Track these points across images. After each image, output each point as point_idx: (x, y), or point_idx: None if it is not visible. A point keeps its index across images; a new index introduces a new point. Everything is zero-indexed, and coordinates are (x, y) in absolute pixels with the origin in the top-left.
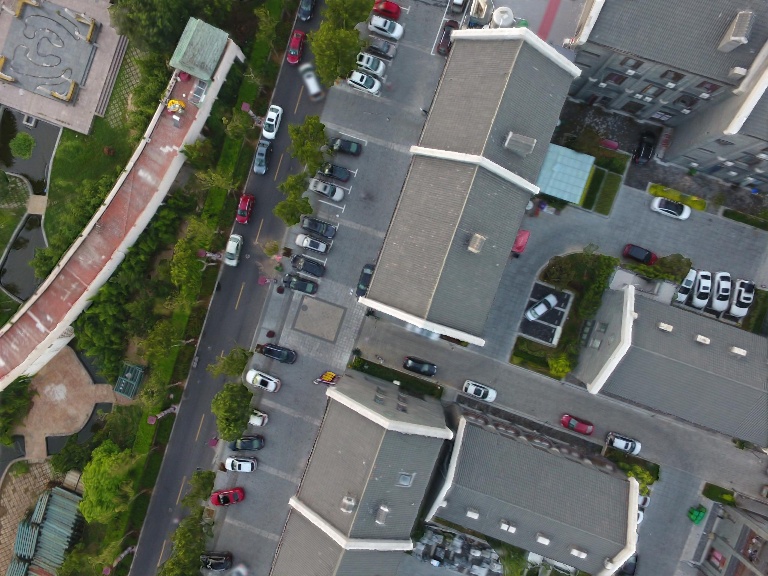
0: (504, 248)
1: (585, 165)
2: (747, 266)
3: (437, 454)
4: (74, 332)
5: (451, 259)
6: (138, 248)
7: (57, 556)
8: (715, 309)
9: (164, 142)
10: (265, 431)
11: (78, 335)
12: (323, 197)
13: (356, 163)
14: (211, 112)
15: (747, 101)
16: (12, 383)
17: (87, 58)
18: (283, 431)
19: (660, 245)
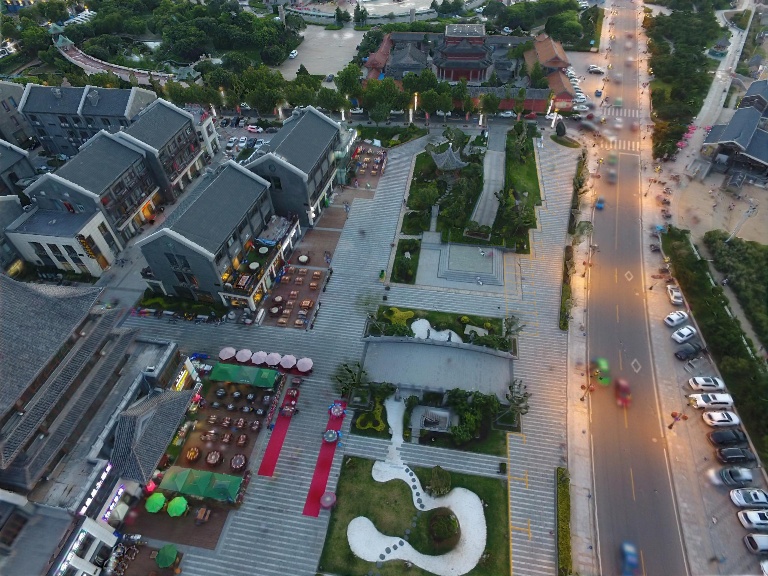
0: (58, 109)
1: None
2: None
3: None
4: None
5: None
6: None
7: None
8: None
9: None
10: None
11: None
12: None
13: None
14: None
15: None
16: None
17: None
18: None
19: None
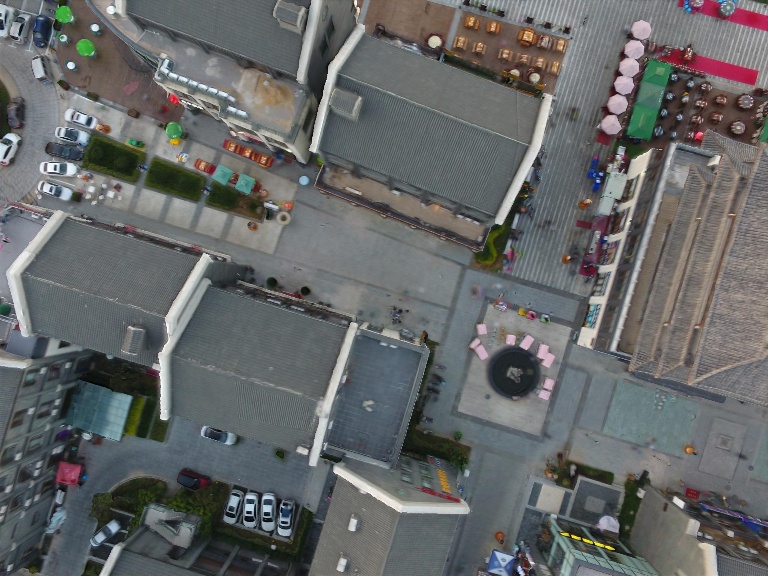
0: None
1: (124, 404)
2: (295, 485)
3: None
4: None
5: None
6: None
7: None
8: (264, 529)
9: None
10: None
11: None
12: None
13: None
14: None
15: None
16: None
17: None
18: None
19: (215, 467)
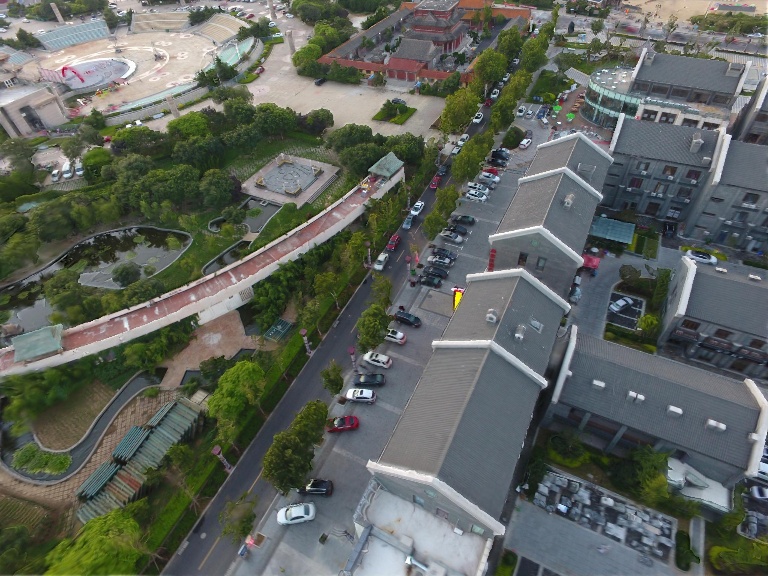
0: (587, 218)
1: (630, 227)
2: None
3: (559, 321)
4: (254, 289)
5: (554, 207)
6: (319, 247)
7: (153, 462)
8: None
9: (353, 203)
10: (387, 374)
11: (257, 289)
12: (448, 241)
13: (471, 228)
14: (383, 197)
15: (717, 166)
16: (189, 317)
17: (311, 181)
18: (403, 375)
19: None
